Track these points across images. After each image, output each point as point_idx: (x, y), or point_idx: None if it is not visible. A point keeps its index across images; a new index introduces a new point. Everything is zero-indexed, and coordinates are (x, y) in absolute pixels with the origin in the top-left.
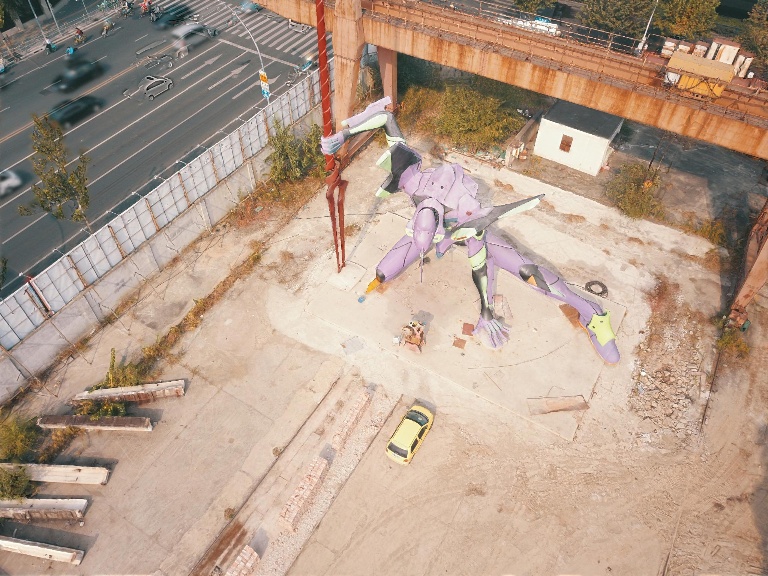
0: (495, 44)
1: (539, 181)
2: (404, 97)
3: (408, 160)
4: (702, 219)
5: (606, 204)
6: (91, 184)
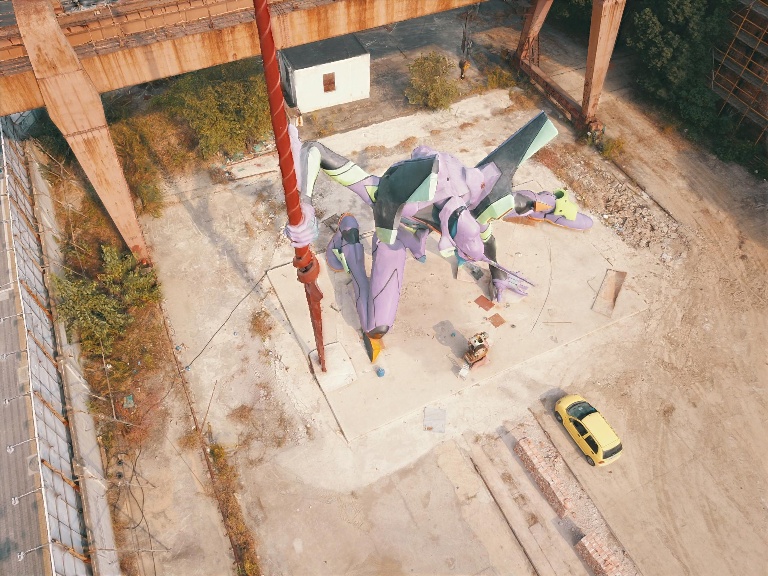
0: None
1: (340, 134)
2: None
3: None
4: (474, 76)
5: (409, 114)
6: None
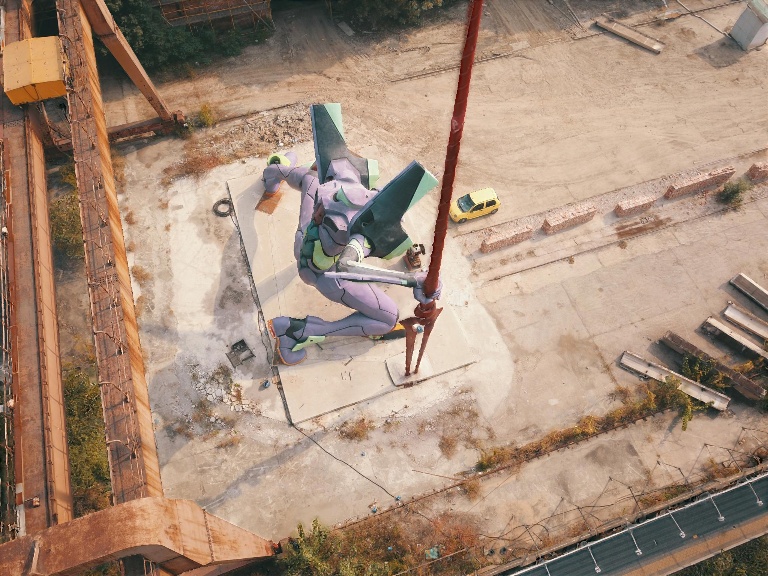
0: None
1: None
2: None
3: None
4: None
5: None
6: None
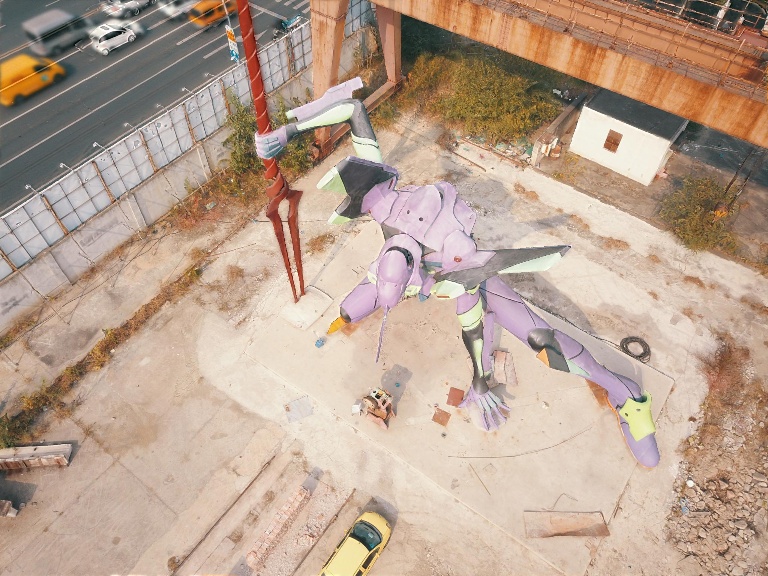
0: (522, 6)
1: (573, 188)
2: (412, 67)
3: (373, 177)
4: None
5: (658, 226)
6: (11, 160)
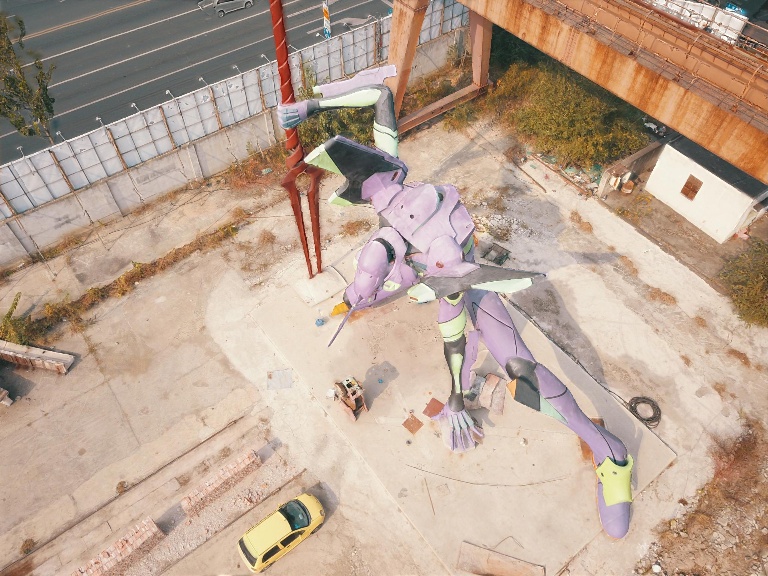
0: (591, 21)
1: (634, 229)
2: (504, 74)
3: (372, 164)
4: None
5: (718, 289)
6: (111, 96)
